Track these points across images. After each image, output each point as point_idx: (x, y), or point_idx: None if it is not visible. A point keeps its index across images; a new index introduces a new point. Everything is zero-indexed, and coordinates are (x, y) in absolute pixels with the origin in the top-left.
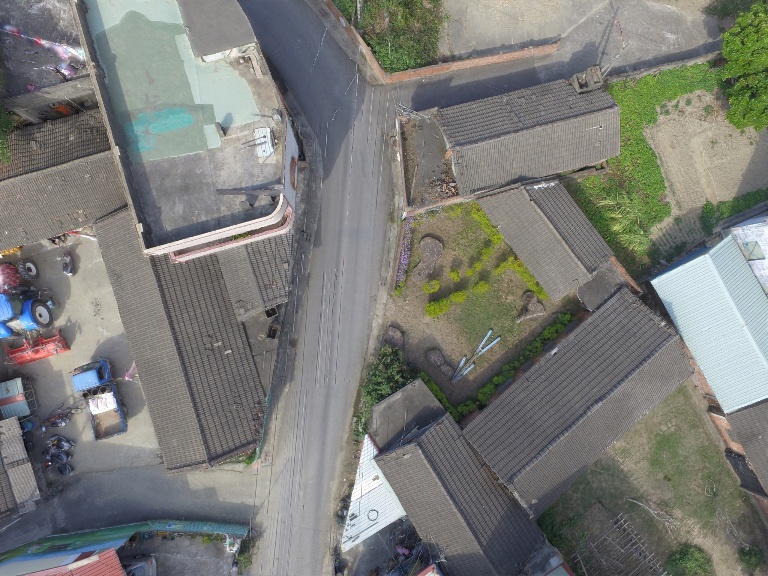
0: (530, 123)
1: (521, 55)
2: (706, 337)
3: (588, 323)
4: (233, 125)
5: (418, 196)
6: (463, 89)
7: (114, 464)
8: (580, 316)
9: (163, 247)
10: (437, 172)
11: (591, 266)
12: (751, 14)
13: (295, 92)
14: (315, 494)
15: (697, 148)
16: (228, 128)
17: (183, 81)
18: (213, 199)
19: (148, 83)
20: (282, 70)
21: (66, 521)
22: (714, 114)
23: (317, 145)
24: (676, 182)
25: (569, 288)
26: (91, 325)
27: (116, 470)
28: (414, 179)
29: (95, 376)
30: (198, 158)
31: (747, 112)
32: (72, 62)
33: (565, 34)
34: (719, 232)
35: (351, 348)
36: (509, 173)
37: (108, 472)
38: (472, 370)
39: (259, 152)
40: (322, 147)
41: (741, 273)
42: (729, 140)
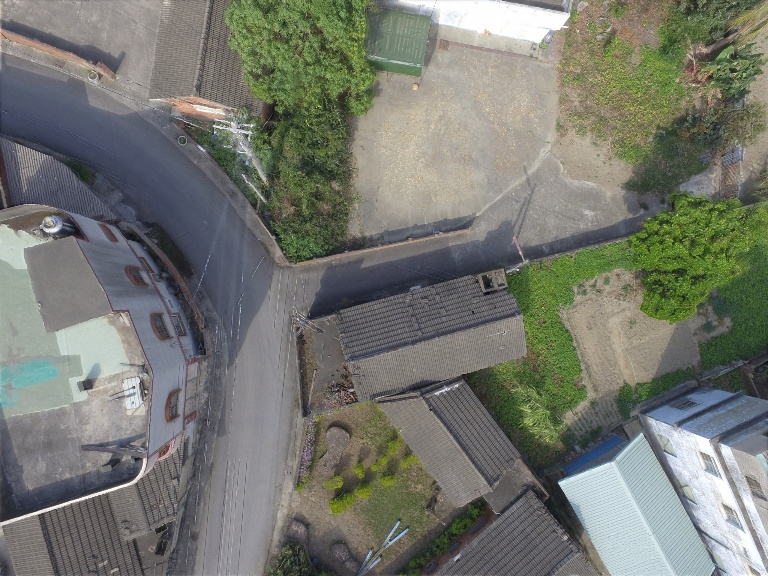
0: (430, 332)
1: (433, 237)
2: (614, 542)
3: (492, 528)
4: (101, 376)
5: (316, 401)
6: (374, 271)
7: None
8: (489, 510)
9: (18, 519)
10: (337, 376)
11: (493, 475)
12: (657, 223)
13: (200, 276)
14: None
15: (615, 328)
16: (95, 380)
17: None
18: (78, 455)
19: (12, 335)
20: (187, 253)
21: None
22: (633, 293)
23: (222, 330)
24: (593, 364)
25: (471, 497)
26: None
27: None
28: (312, 384)
29: None
30: (63, 412)
31: (659, 308)
32: None
33: (480, 212)
34: (637, 415)
35: (254, 541)
36: (410, 379)
37: None
38: (379, 563)
39: (128, 404)
40: (227, 332)
41: (651, 475)
42: (648, 320)
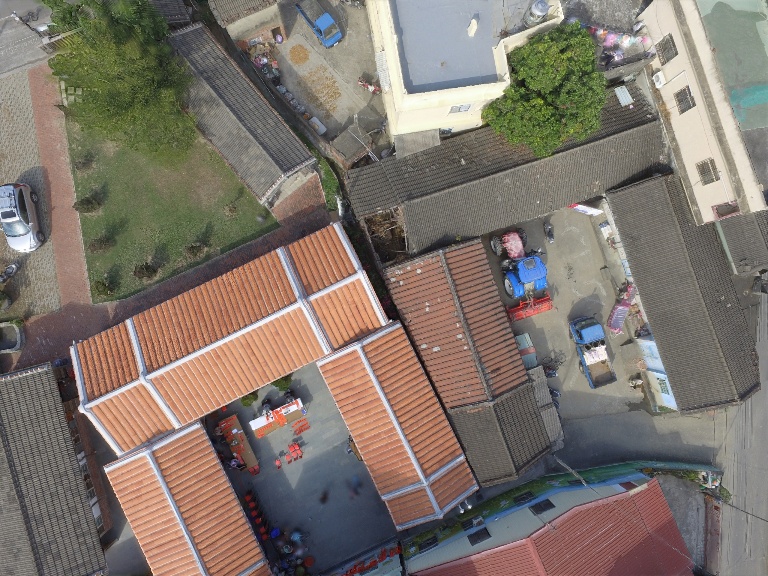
0: None
1: None
2: None
3: None
4: None
5: None
6: None
7: (590, 412)
8: None
9: None
10: None
11: None
12: None
13: None
14: (765, 437)
15: None
16: None
17: (764, 62)
18: None
19: (737, 64)
20: None
21: (556, 462)
22: None
23: None
24: None
25: None
26: (566, 287)
27: (593, 417)
28: None
29: (601, 330)
30: None
31: None
32: (605, 50)
33: None
34: None
35: None
36: None
37: (586, 419)
38: None
39: None
40: None
41: None
42: None
